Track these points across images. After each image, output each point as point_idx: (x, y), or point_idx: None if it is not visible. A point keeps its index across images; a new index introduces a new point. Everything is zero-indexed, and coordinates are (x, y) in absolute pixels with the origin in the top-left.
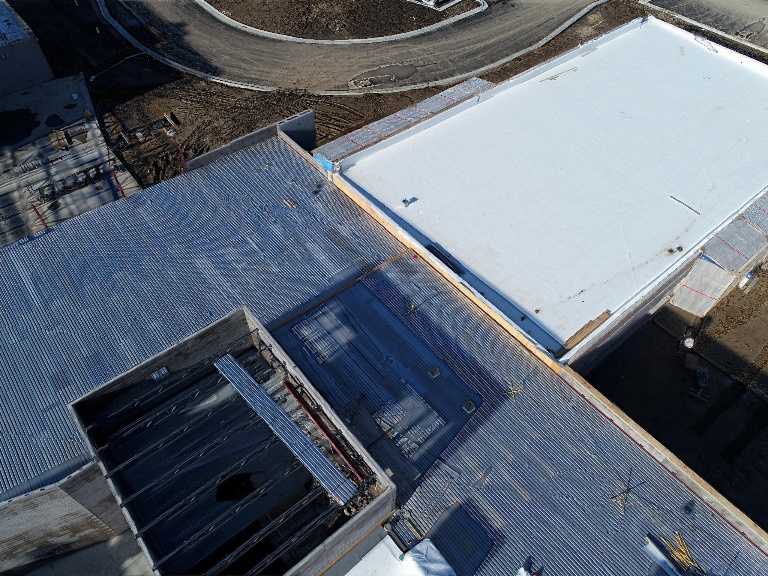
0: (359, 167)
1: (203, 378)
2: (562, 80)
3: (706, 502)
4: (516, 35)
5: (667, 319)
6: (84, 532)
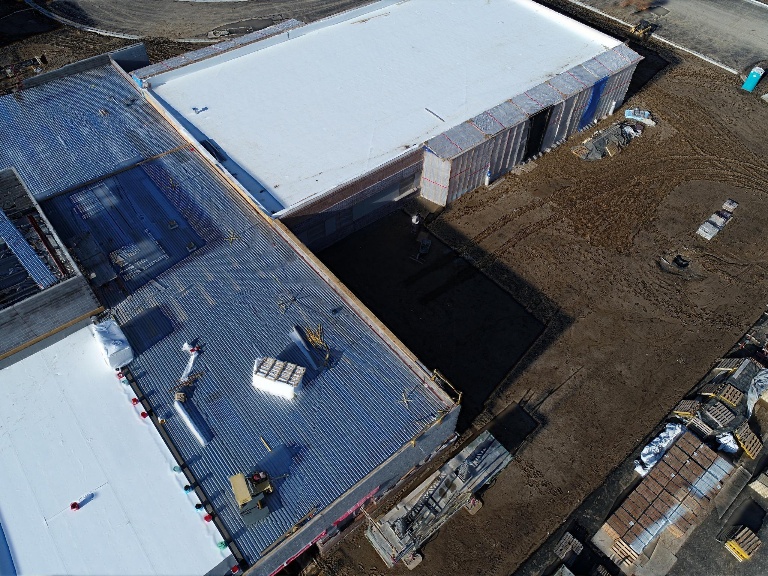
0: (168, 85)
1: None
2: (371, 23)
3: (352, 308)
4: None
5: (414, 208)
6: None
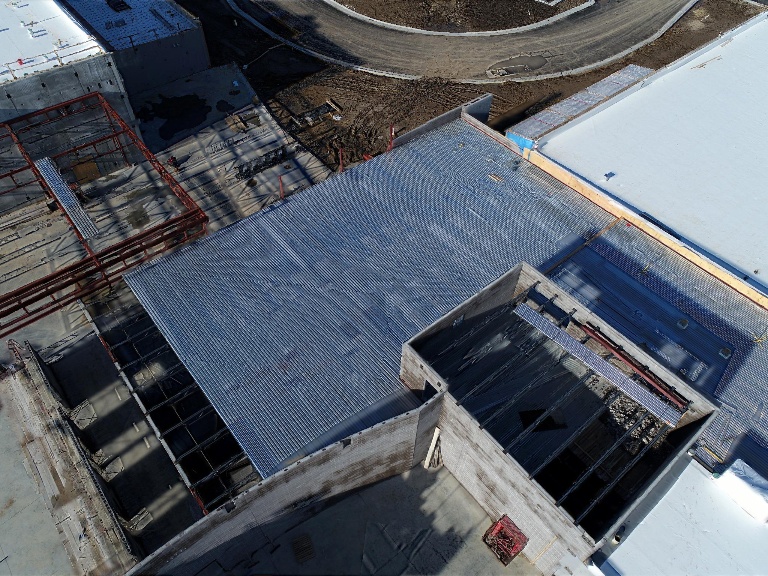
0: (551, 145)
1: None
2: (710, 68)
3: None
4: (630, 28)
5: None
6: (396, 463)
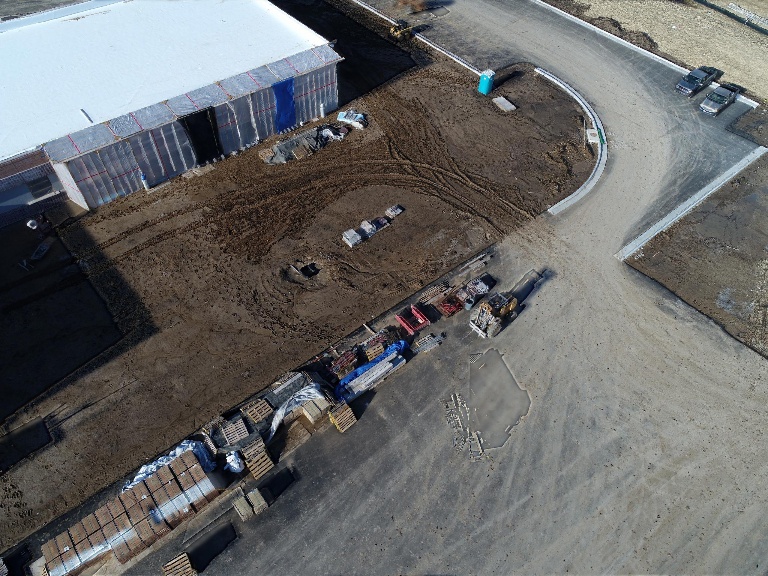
0: None
1: None
2: (84, 20)
3: None
4: None
5: (57, 212)
6: None
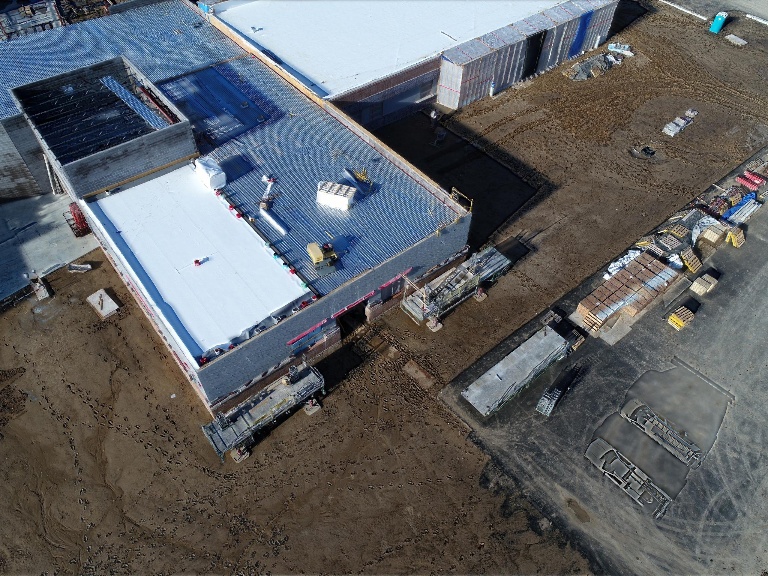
0: (228, 12)
1: (100, 107)
2: None
3: (388, 159)
4: None
5: None
6: (20, 180)
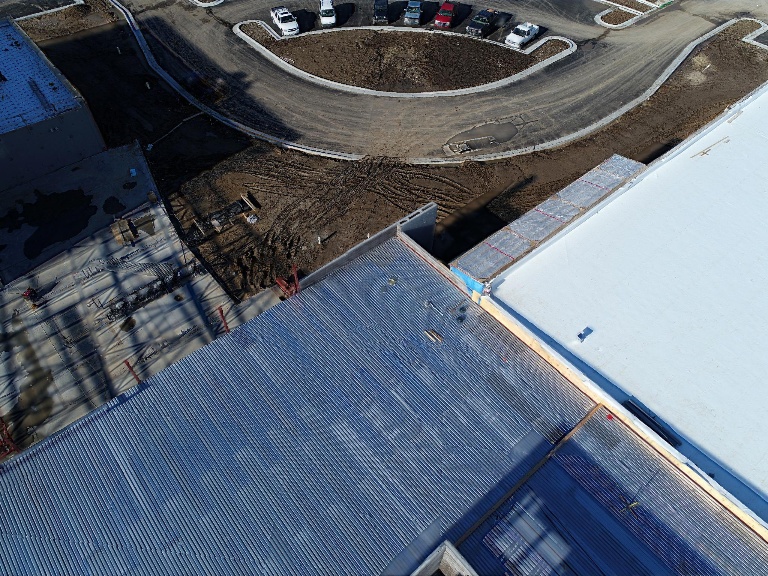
0: (510, 284)
1: None
2: (715, 155)
3: None
4: (618, 83)
5: None
6: None
